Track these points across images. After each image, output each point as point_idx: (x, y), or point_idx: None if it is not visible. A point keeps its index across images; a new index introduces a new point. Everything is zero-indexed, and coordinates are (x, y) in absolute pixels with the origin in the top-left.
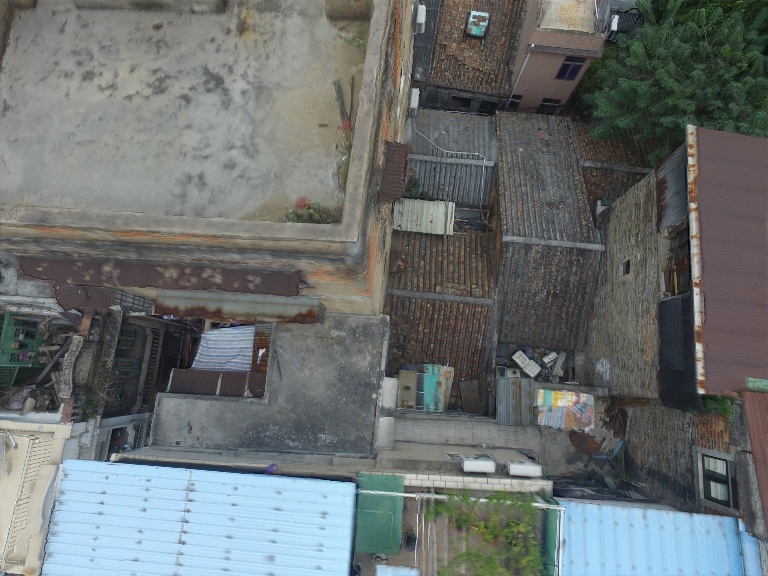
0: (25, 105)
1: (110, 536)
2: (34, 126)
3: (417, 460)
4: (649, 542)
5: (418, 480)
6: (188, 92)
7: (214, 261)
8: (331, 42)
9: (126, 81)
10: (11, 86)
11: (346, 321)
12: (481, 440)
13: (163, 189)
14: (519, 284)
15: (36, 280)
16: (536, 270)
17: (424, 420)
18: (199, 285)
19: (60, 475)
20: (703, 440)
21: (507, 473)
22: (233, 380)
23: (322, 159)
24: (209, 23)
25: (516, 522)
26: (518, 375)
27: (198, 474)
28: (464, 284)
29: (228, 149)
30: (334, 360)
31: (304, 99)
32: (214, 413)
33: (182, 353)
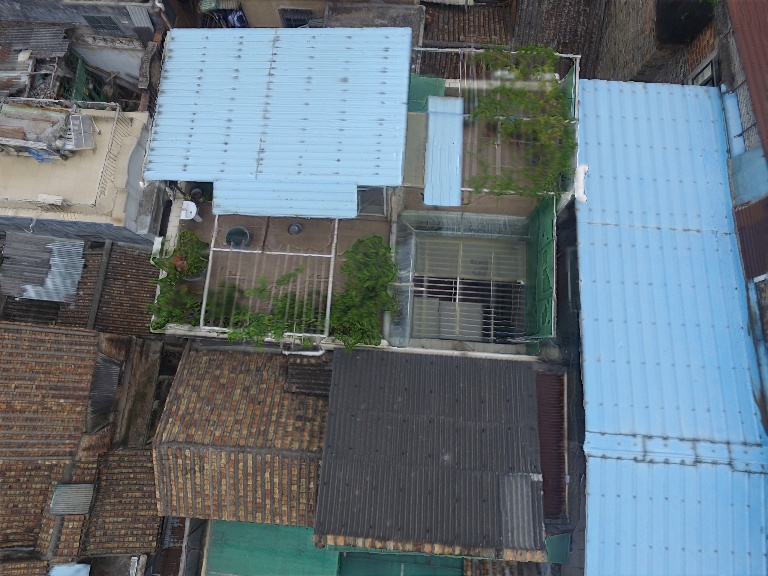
0: None
1: (212, 75)
2: None
3: None
4: (648, 102)
5: (456, 83)
6: None
7: None
8: None
9: None
10: None
11: (388, 12)
12: None
13: None
14: (533, 35)
15: None
16: (548, 21)
17: None
18: None
19: (168, 38)
20: (693, 65)
21: None
22: None
23: None
24: None
25: (541, 64)
26: None
27: (282, 30)
28: (484, 36)
29: None
30: None
31: None
32: None
33: None
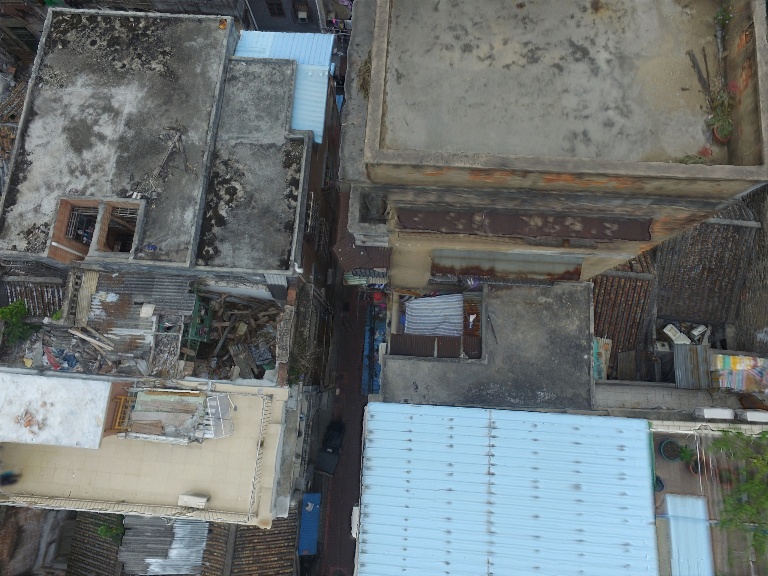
0: (416, 74)
1: (422, 469)
2: (428, 92)
3: (646, 411)
4: None
5: (664, 426)
6: (559, 62)
7: (582, 209)
8: (679, 18)
9: (502, 53)
10: (399, 58)
11: (552, 288)
12: (656, 404)
13: (554, 144)
14: (676, 260)
15: (251, 253)
16: (693, 246)
17: (602, 386)
18: (562, 232)
19: (366, 416)
20: None
21: (744, 419)
22: (448, 344)
23: (690, 118)
24: (567, 2)
25: None
26: (667, 348)
27: (497, 413)
28: None
29: (604, 110)
30: (544, 324)
31: (663, 67)
32: (437, 373)
33: (327, 332)
